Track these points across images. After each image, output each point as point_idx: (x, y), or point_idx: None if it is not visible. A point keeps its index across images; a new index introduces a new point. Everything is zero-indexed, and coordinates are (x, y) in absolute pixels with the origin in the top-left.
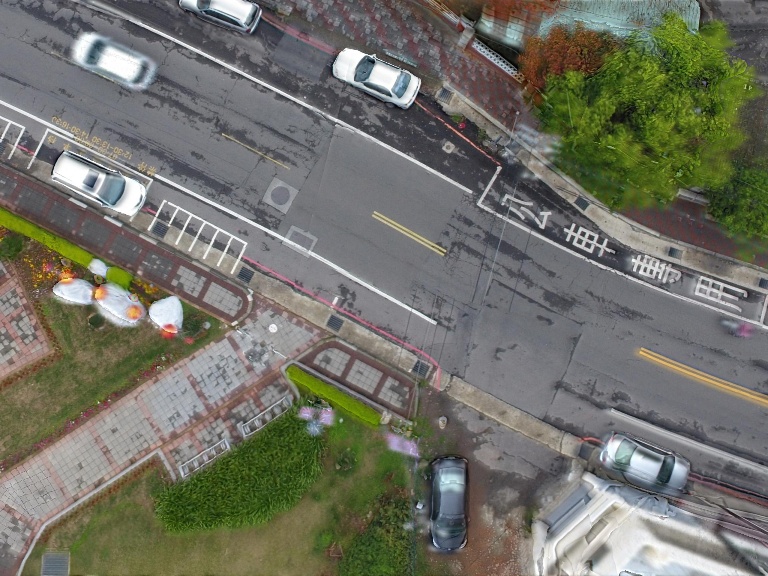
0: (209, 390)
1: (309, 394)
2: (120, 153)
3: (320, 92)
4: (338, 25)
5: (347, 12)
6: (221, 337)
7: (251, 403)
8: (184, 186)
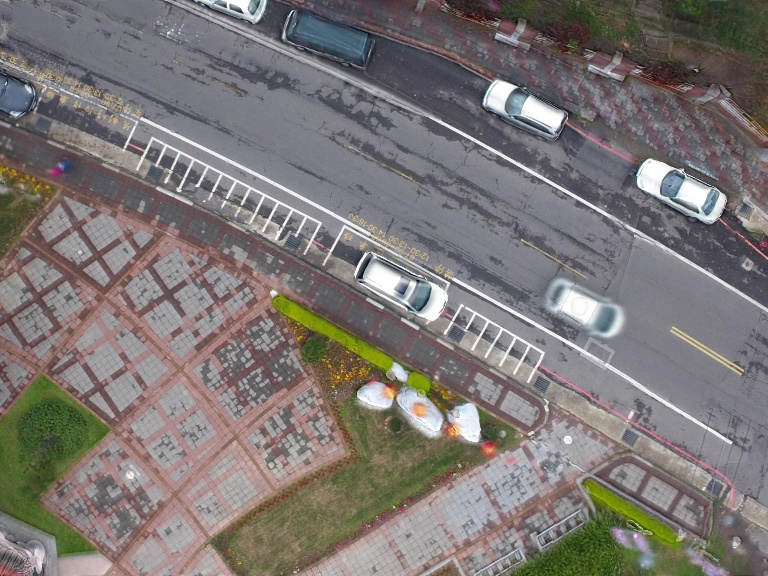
0: (504, 499)
1: (606, 509)
2: (417, 254)
3: (621, 201)
4: (643, 134)
5: (652, 121)
6: (516, 446)
7: (545, 514)
8: (482, 291)
